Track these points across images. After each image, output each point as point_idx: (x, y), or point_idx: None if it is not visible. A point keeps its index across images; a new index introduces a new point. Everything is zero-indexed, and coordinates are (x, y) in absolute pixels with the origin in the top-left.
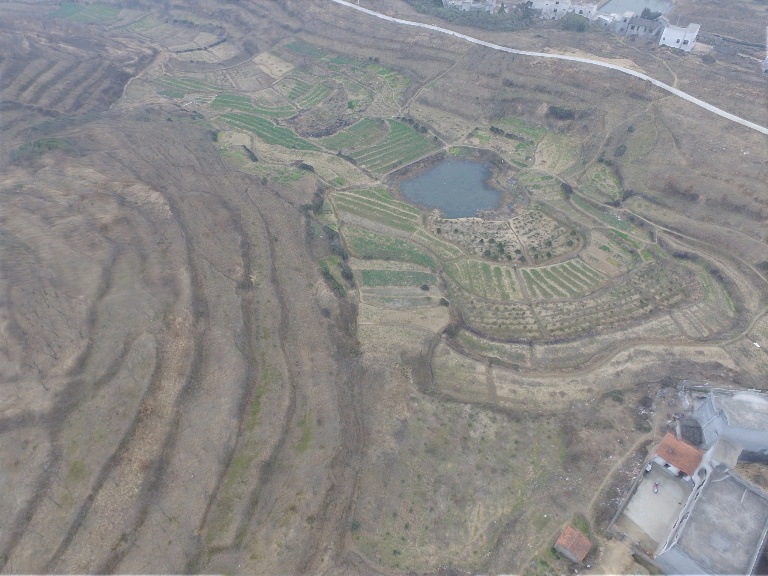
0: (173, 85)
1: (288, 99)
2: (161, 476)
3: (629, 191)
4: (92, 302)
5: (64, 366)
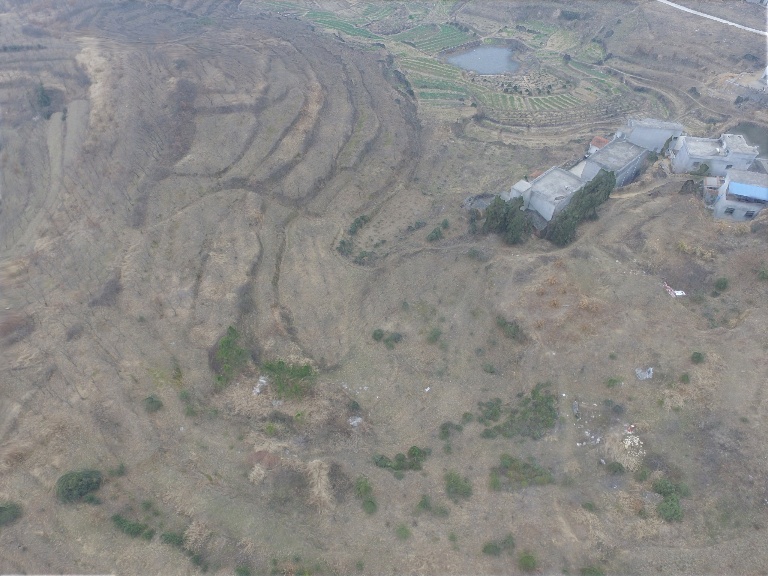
0: (274, 6)
1: (362, 15)
2: (314, 138)
3: (609, 54)
4: (264, 73)
5: (259, 88)
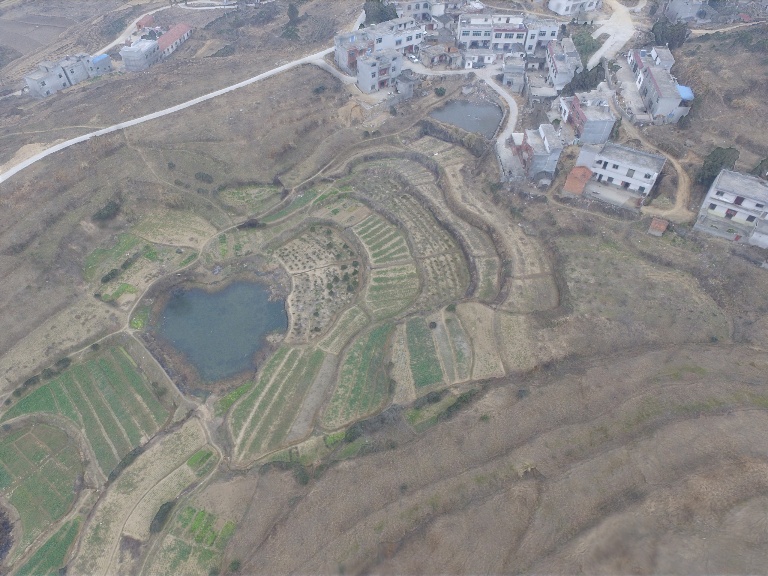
0: None
1: None
2: None
3: (277, 179)
4: None
5: None
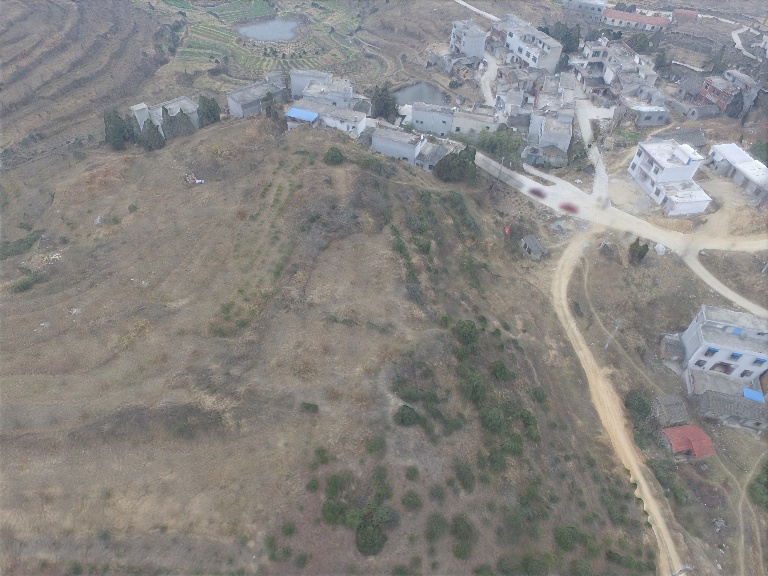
0: None
1: None
2: (25, 72)
3: (359, 26)
4: (14, 21)
5: None
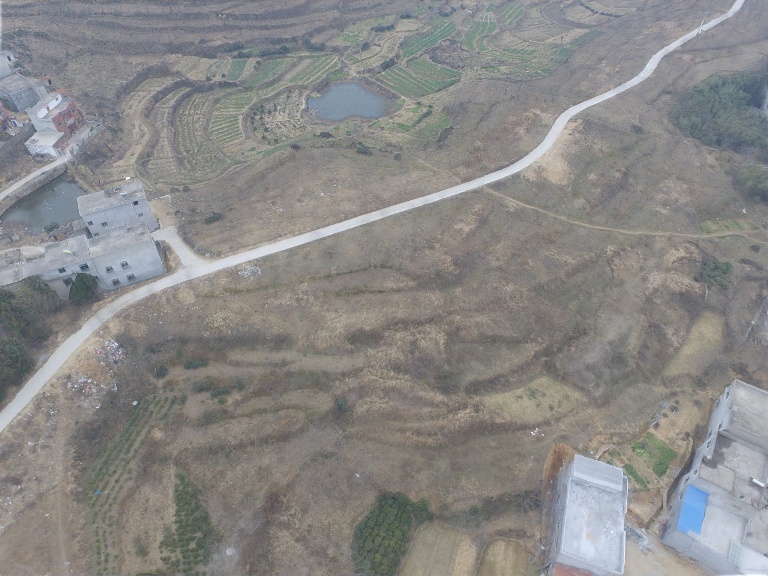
0: (510, 8)
1: None
2: (114, 2)
3: None
4: None
5: None
